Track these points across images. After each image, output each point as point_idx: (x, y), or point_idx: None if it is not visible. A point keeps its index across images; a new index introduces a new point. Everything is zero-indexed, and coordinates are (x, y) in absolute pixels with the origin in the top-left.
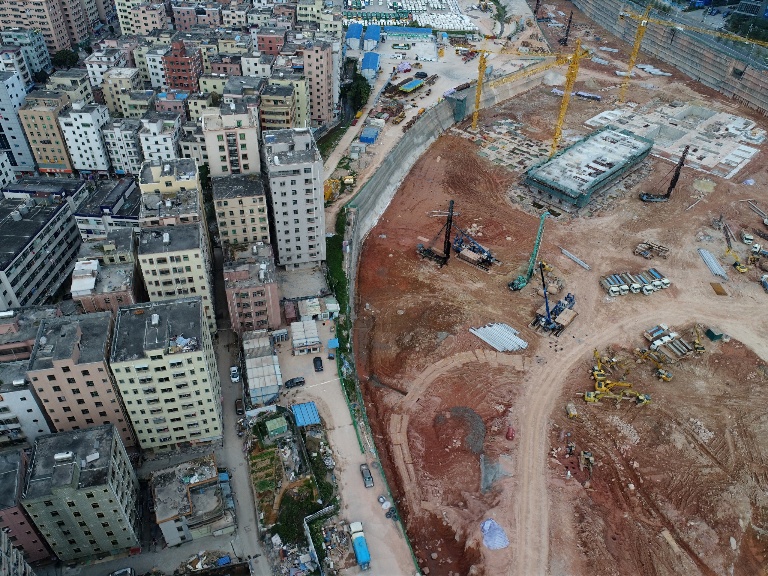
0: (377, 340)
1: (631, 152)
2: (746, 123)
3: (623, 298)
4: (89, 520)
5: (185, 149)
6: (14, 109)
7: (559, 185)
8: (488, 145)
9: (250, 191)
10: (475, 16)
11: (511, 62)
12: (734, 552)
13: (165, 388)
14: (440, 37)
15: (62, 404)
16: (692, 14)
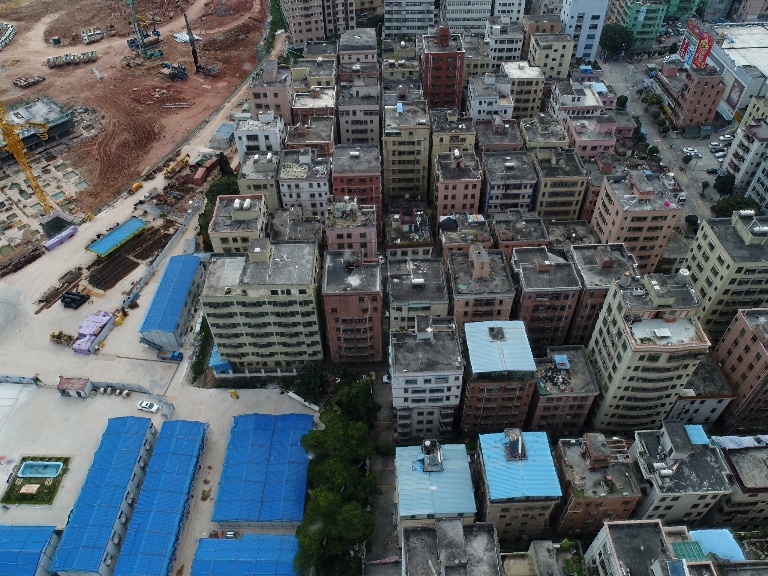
0: None
1: None
2: None
3: None
4: None
5: None
6: None
7: None
8: None
9: None
10: None
11: None
12: None
13: None
14: None
15: None
16: None
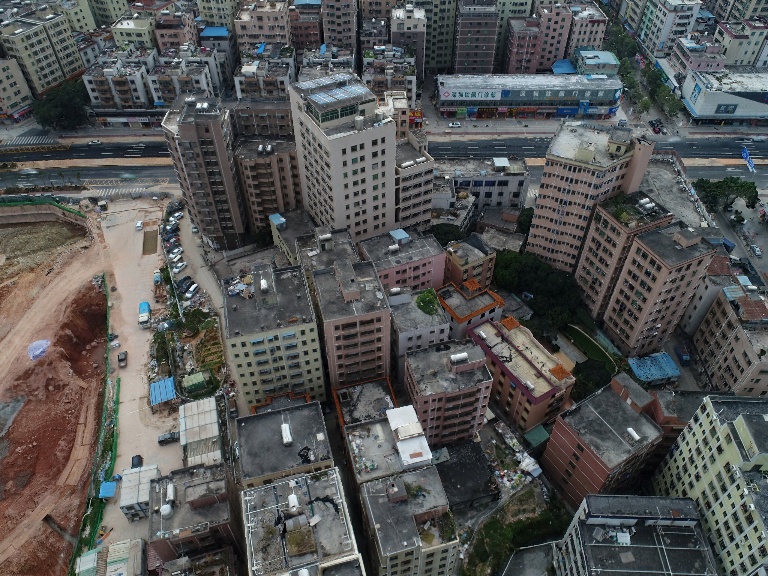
0: None
1: None
2: None
3: None
4: None
5: None
6: None
7: None
8: None
9: None
10: None
11: None
12: None
13: None
14: None
15: None
16: None
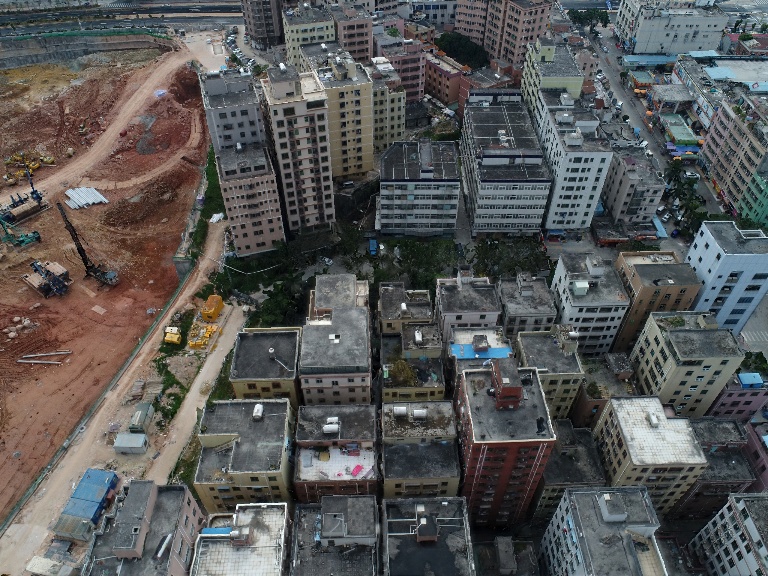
0: (194, 197)
1: None
2: None
3: None
4: None
5: None
6: None
7: None
8: None
9: None
10: None
11: None
12: (38, 108)
13: None
14: None
15: None
16: None
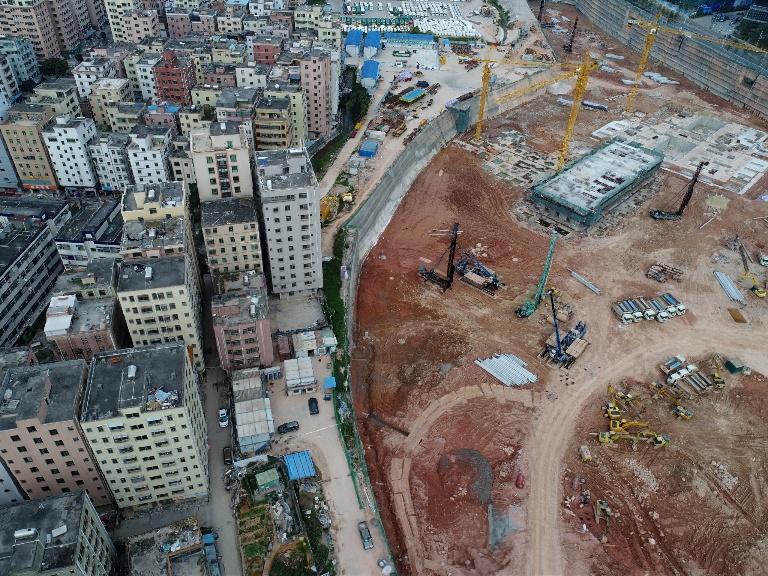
0: (377, 373)
1: (641, 166)
2: (758, 134)
3: (636, 326)
4: None
5: (176, 165)
6: None
7: (567, 202)
8: (492, 158)
9: (241, 217)
10: (477, 22)
11: (515, 70)
12: None
13: (143, 446)
14: (442, 44)
15: (29, 465)
16: (700, 20)
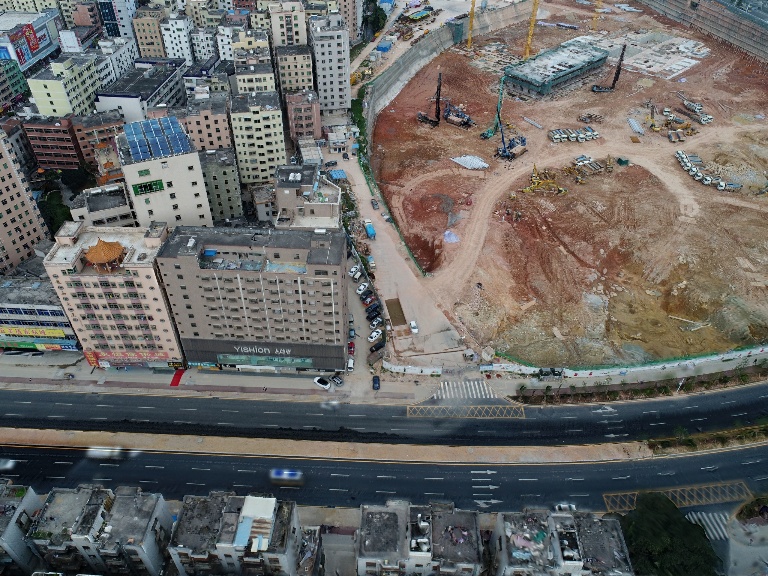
0: (386, 164)
1: (589, 58)
2: (696, 44)
3: (563, 144)
4: (222, 193)
5: None
6: (129, 18)
7: (527, 77)
8: (479, 58)
9: (301, 52)
10: None
11: None
12: (601, 255)
13: (259, 136)
14: None
15: (201, 144)
16: None
